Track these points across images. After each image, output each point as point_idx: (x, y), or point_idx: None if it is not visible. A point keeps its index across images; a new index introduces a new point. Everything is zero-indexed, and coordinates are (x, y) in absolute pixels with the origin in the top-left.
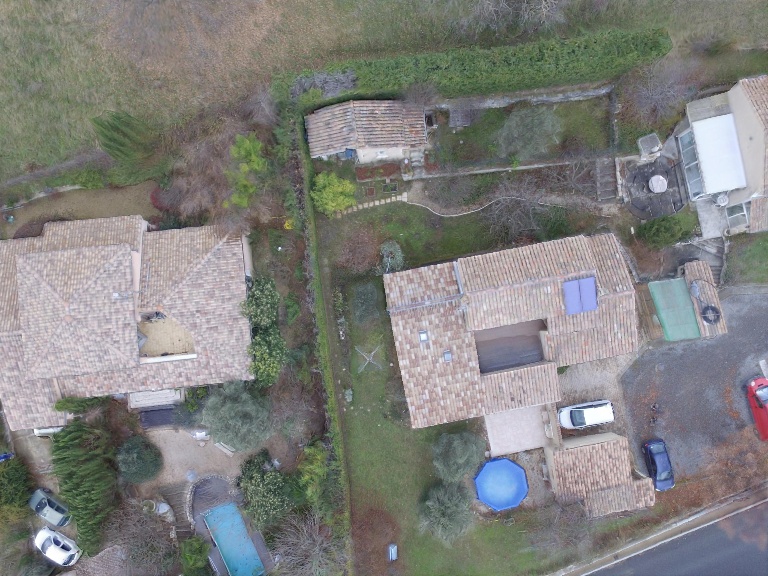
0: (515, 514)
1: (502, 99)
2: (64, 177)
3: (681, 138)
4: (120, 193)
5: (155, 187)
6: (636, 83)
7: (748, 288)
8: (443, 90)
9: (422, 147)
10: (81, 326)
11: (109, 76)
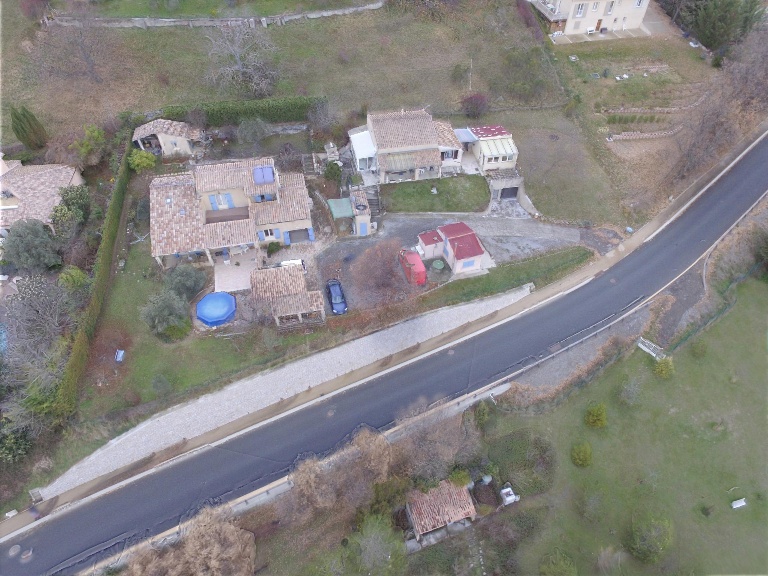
0: None
1: None
2: None
3: None
4: None
5: None
6: (311, 113)
7: (401, 215)
8: (213, 119)
9: None
10: None
11: None
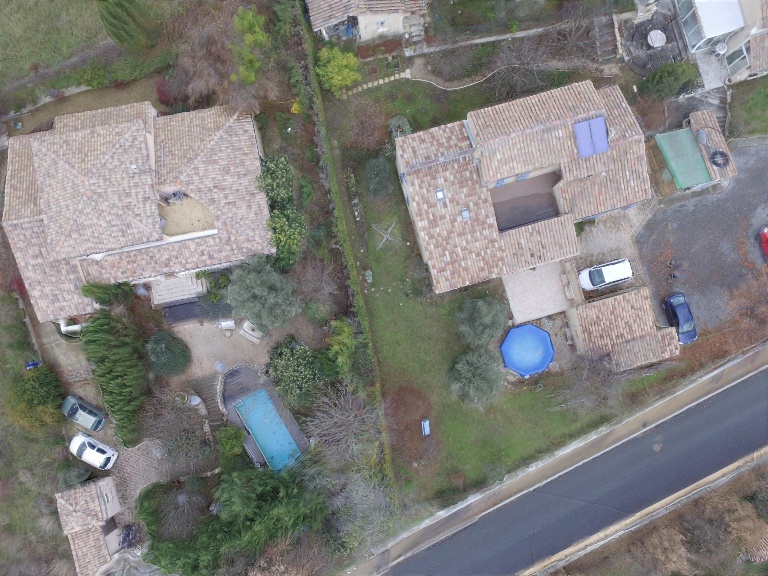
0: (542, 380)
1: None
2: (69, 77)
3: None
4: (126, 92)
5: (160, 82)
6: None
7: (753, 139)
8: None
9: (421, 19)
10: (102, 200)
11: None
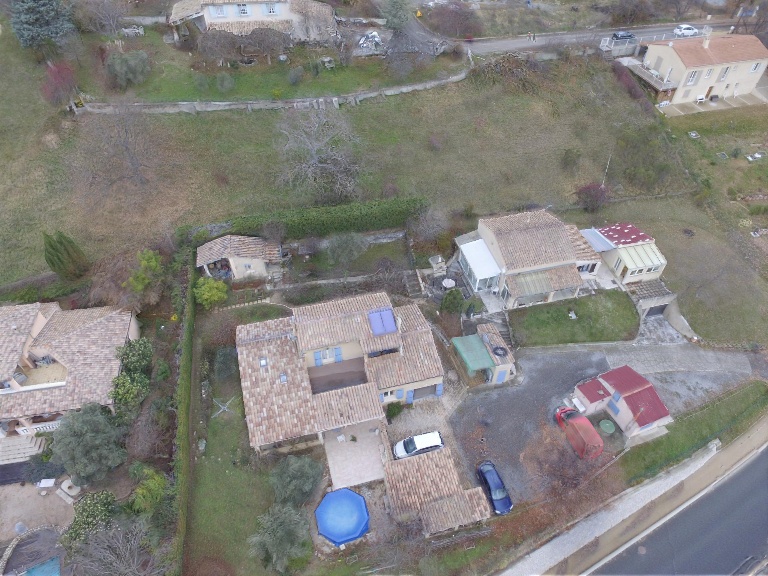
0: (359, 551)
1: None
2: (10, 294)
3: (461, 261)
4: None
5: None
6: (413, 221)
7: (538, 349)
8: (292, 231)
9: (281, 269)
10: None
11: (69, 236)
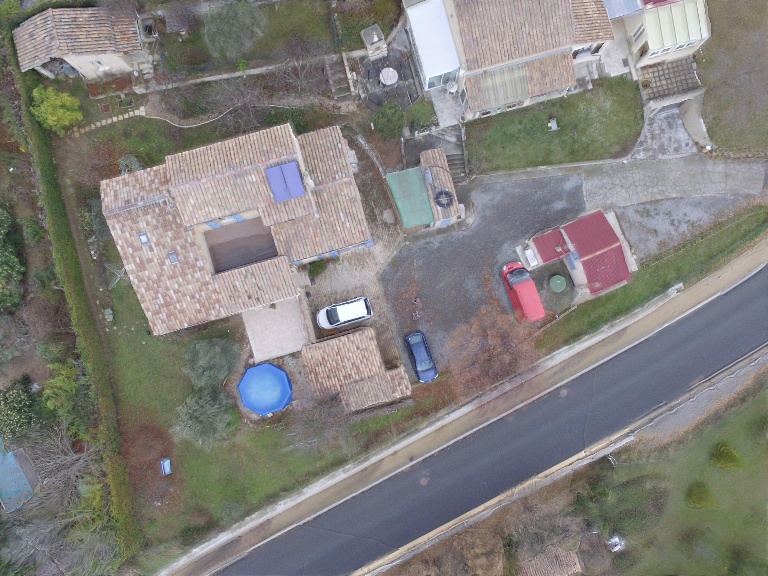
0: (285, 418)
1: (217, 1)
2: None
3: (410, 29)
4: None
5: None
6: None
7: (498, 176)
8: None
9: (148, 57)
10: None
11: None
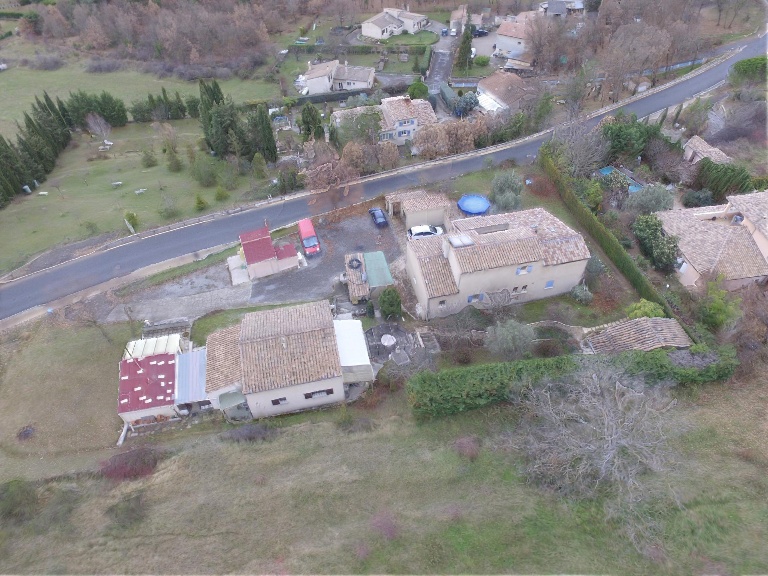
0: None
1: None
2: None
3: None
4: None
5: None
6: None
7: None
8: None
9: None
10: None
11: None
